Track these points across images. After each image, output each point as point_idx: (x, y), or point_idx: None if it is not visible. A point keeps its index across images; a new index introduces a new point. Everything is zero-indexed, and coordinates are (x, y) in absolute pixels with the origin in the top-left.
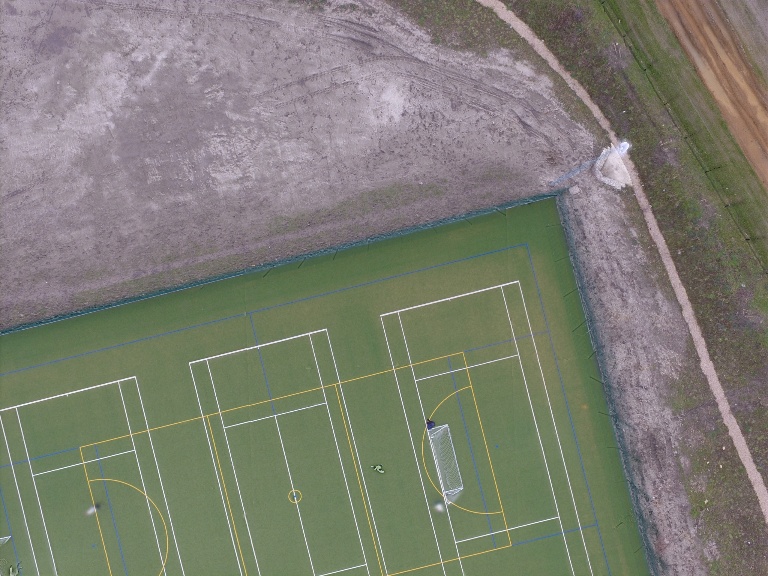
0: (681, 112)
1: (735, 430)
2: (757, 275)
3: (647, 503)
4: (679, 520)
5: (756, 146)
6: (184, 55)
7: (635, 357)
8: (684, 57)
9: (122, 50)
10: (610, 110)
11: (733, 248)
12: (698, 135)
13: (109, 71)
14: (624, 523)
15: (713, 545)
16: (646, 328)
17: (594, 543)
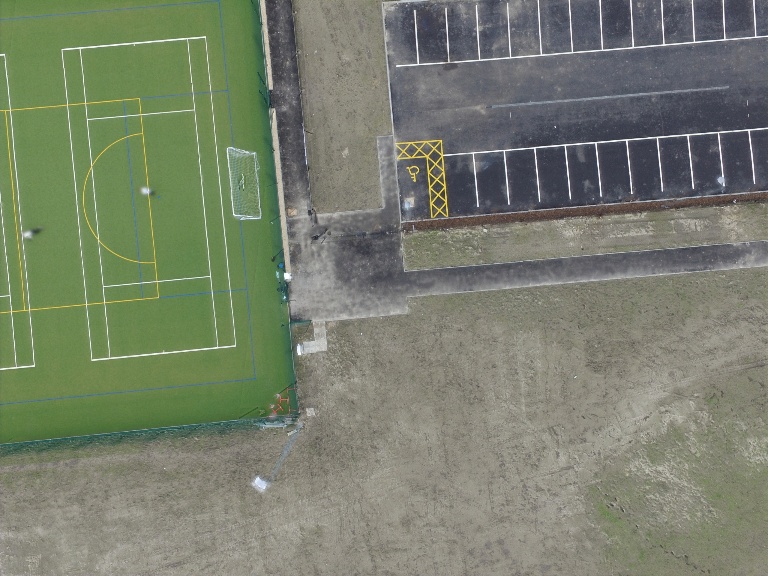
0: None
1: None
2: None
3: None
4: None
5: None
6: None
7: None
8: None
9: None
10: None
11: None
12: None
13: None
14: None
15: None
16: None
17: None
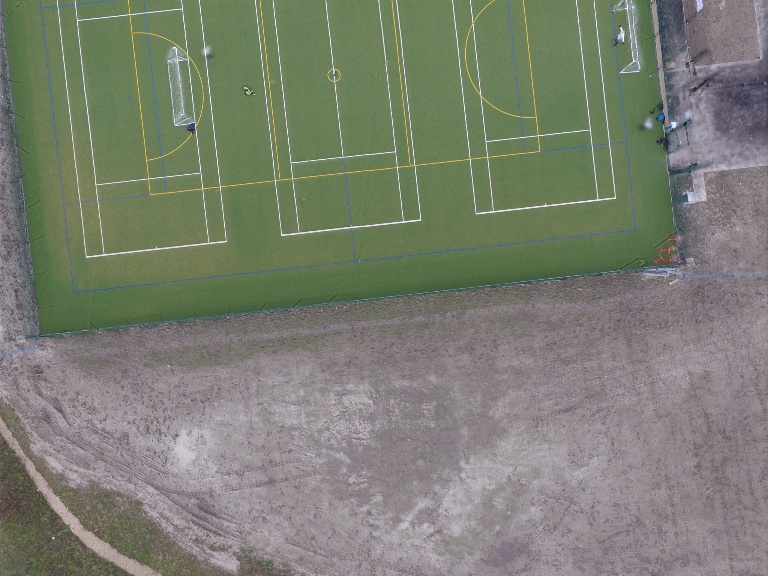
0: None
1: None
2: None
3: None
4: None
5: None
6: (382, 523)
7: None
8: None
9: (442, 536)
10: None
11: None
12: None
13: (458, 518)
14: (14, 6)
15: None
16: None
17: None
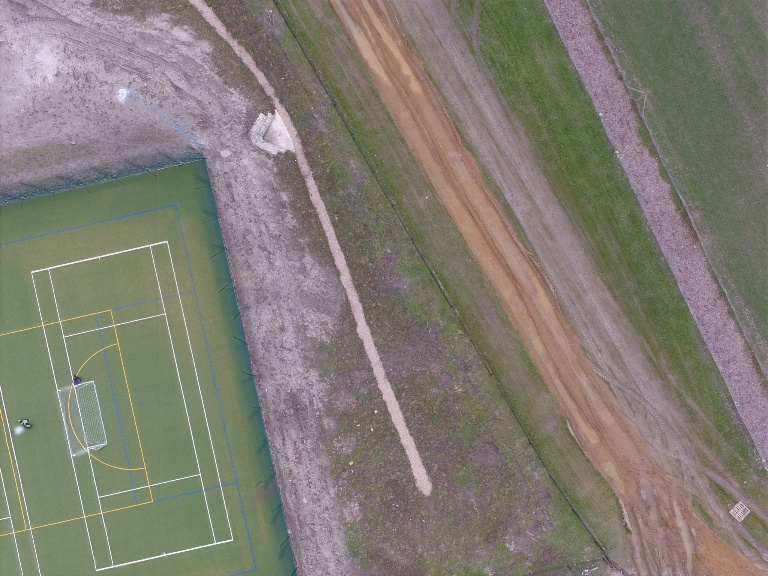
0: (333, 79)
1: (389, 394)
2: (403, 241)
3: (287, 463)
4: (319, 480)
5: (408, 115)
6: None
7: (280, 319)
8: (339, 26)
9: None
10: (272, 77)
11: (379, 214)
12: (349, 102)
13: None
14: (263, 482)
15: (355, 506)
16: (292, 290)
17: (234, 501)
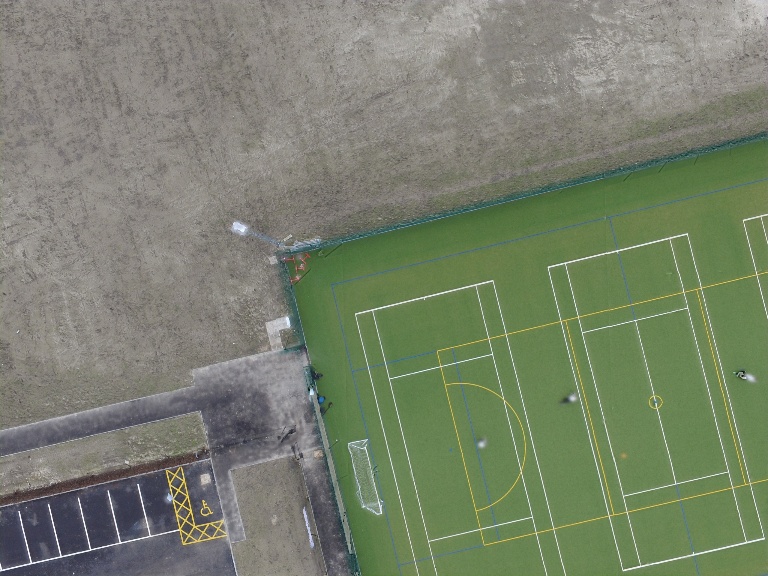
0: None
1: None
2: None
3: None
4: None
5: None
6: None
7: None
8: None
9: None
10: None
11: None
12: None
13: None
14: None
15: None
16: None
17: None
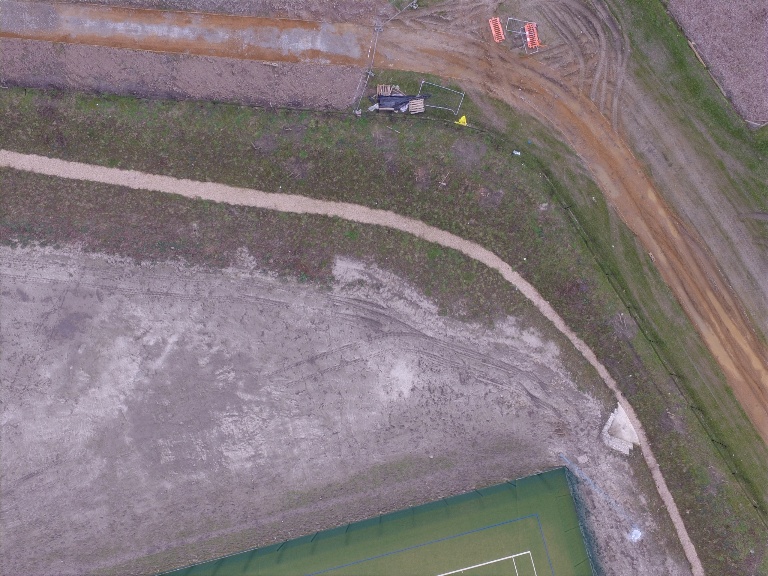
0: (687, 380)
1: None
2: (765, 541)
3: None
4: None
5: (761, 410)
6: (195, 338)
7: None
8: (688, 324)
9: (134, 334)
10: (616, 372)
11: (741, 515)
12: (704, 402)
13: (121, 355)
14: None
15: None
16: None
17: None
